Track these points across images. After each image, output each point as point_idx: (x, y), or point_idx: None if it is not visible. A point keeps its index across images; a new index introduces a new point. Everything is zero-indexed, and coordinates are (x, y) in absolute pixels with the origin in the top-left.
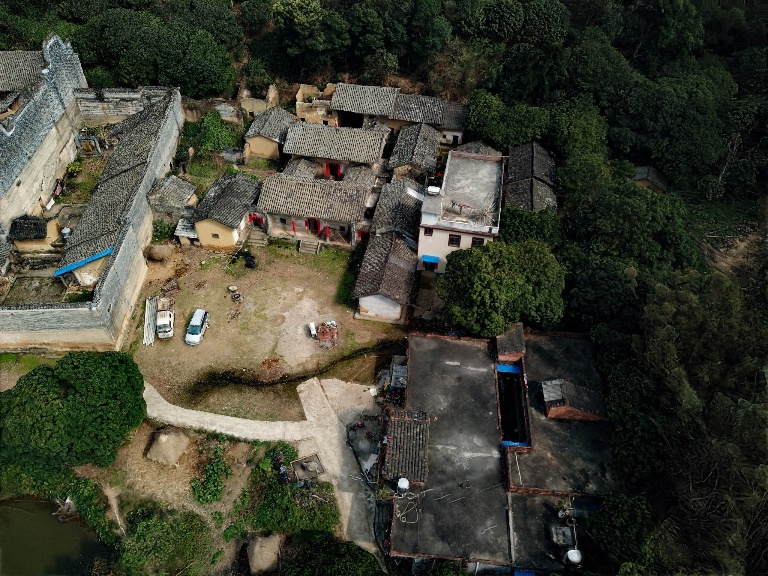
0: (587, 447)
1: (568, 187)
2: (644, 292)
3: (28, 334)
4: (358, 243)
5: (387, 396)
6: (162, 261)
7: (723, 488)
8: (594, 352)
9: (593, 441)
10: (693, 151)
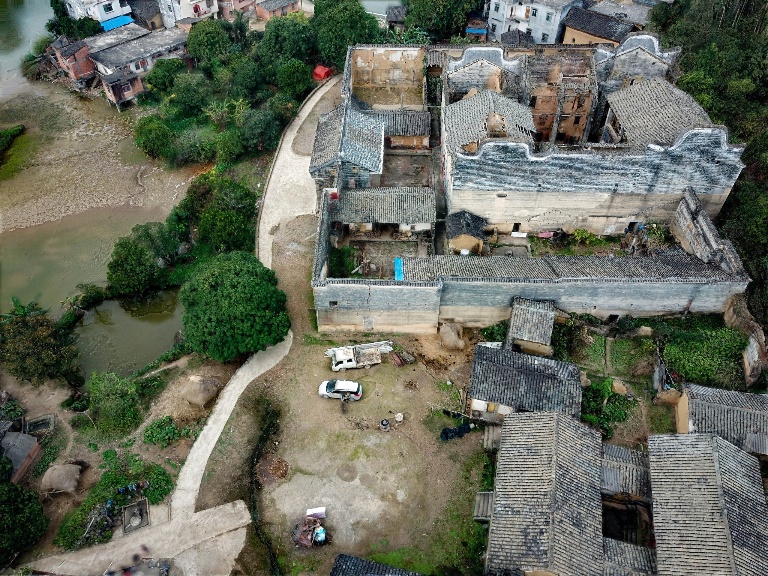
0: None
1: None
2: None
3: None
4: None
5: None
6: None
7: None
8: None
9: None
10: None
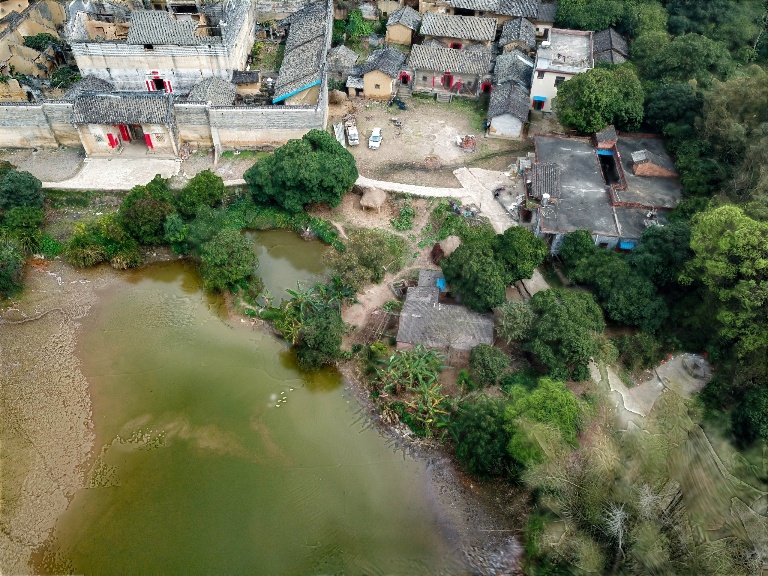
0: (663, 189)
1: (639, 54)
2: (701, 100)
3: (267, 133)
4: (481, 95)
5: (518, 174)
6: (338, 104)
7: (756, 178)
8: (664, 145)
9: (667, 186)
10: (734, 30)
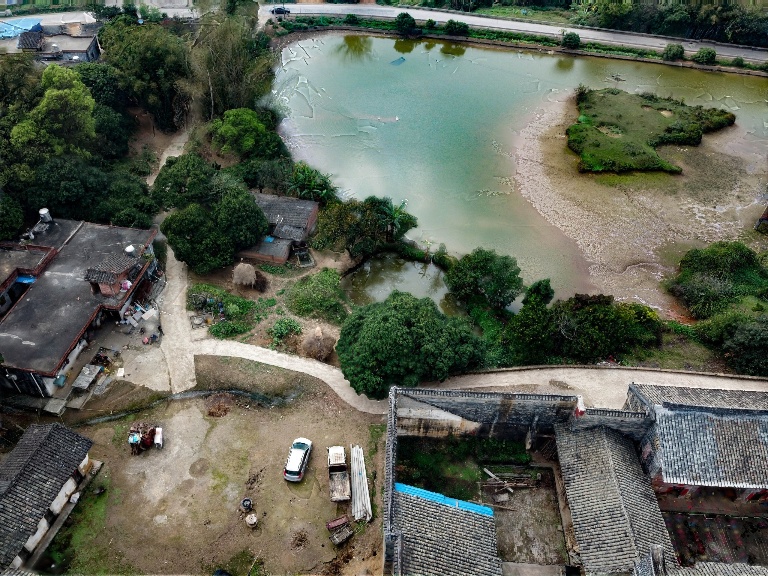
0: None
1: None
2: None
3: None
4: None
5: None
6: None
7: None
8: None
9: None
10: None
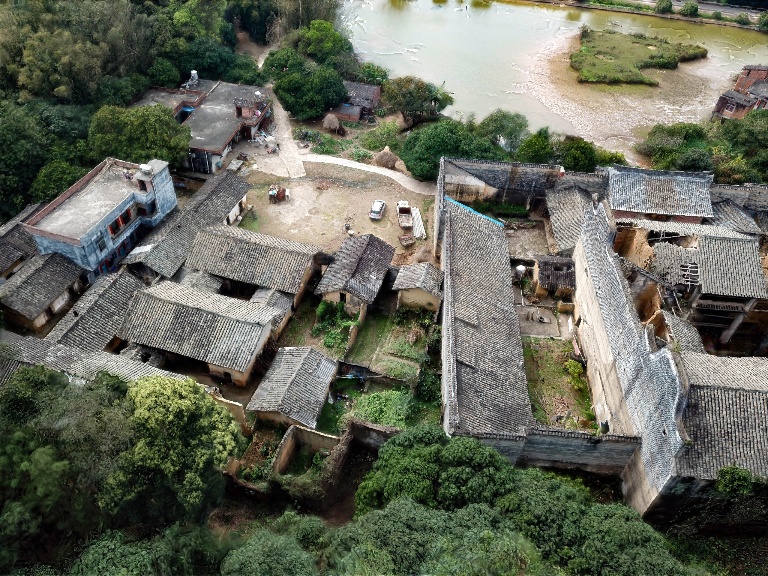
0: None
1: None
2: None
3: None
4: None
5: None
6: None
7: None
8: None
9: None
10: None
